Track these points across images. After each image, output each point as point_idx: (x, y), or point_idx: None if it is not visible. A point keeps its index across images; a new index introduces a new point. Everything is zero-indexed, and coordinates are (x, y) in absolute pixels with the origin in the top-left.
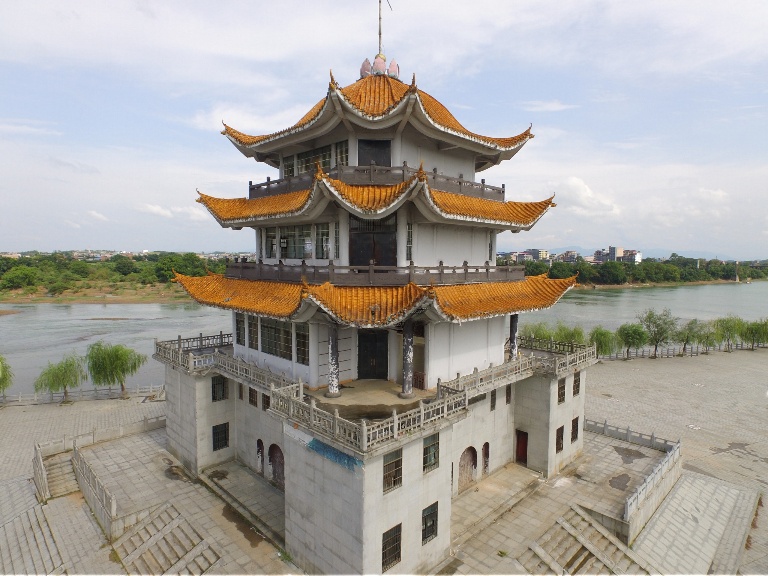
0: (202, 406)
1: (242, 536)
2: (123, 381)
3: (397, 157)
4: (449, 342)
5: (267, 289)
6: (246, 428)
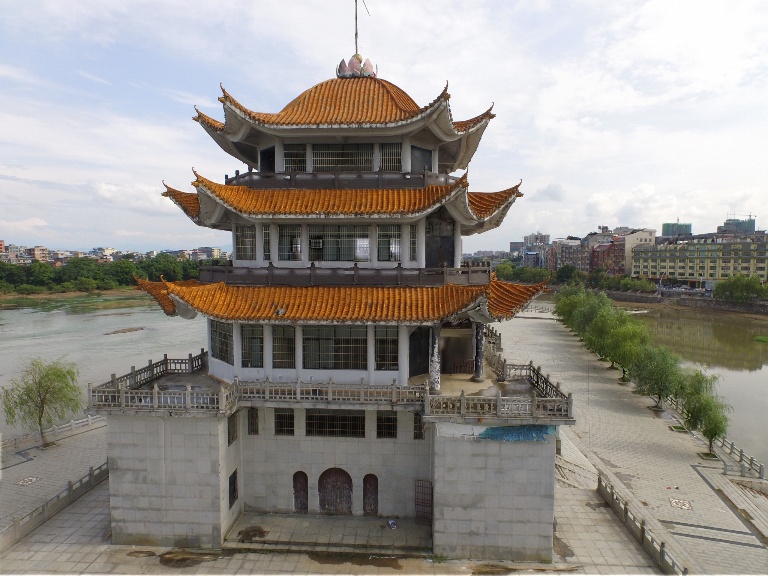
0: (222, 455)
1: (375, 567)
2: None
3: None
4: None
5: (341, 295)
6: (267, 467)
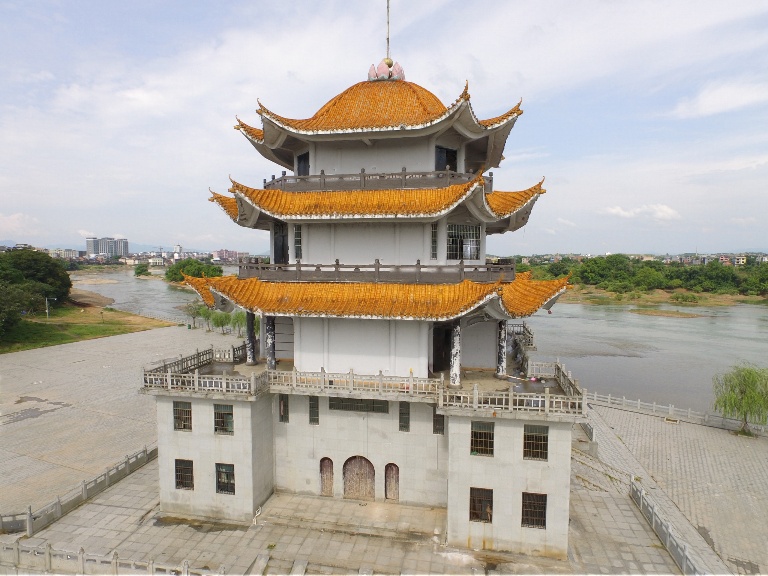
0: None
1: None
2: None
3: (310, 165)
4: (323, 339)
5: None
6: None
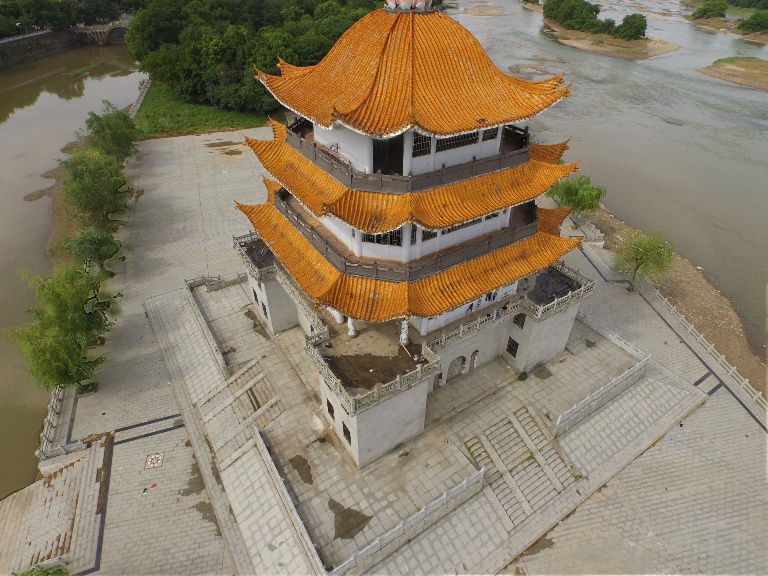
0: None
1: None
2: (572, 214)
3: None
4: None
5: None
6: None
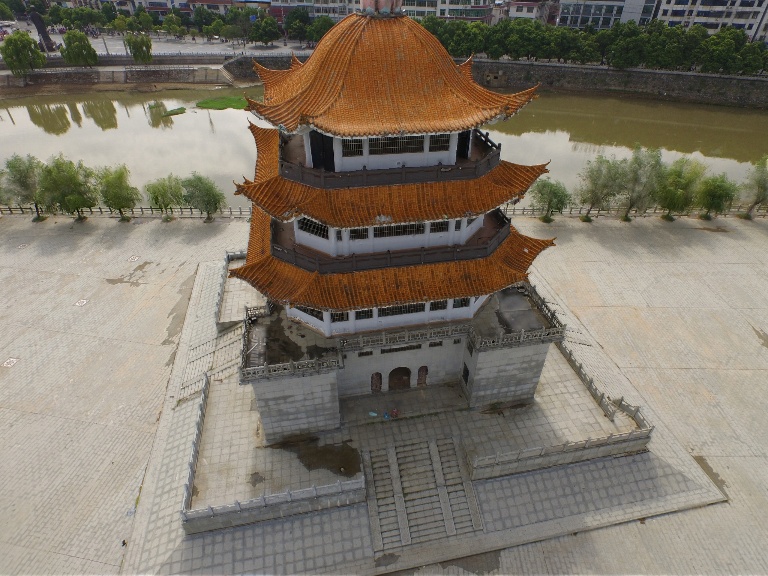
0: None
1: None
2: None
3: None
4: None
5: None
6: None
